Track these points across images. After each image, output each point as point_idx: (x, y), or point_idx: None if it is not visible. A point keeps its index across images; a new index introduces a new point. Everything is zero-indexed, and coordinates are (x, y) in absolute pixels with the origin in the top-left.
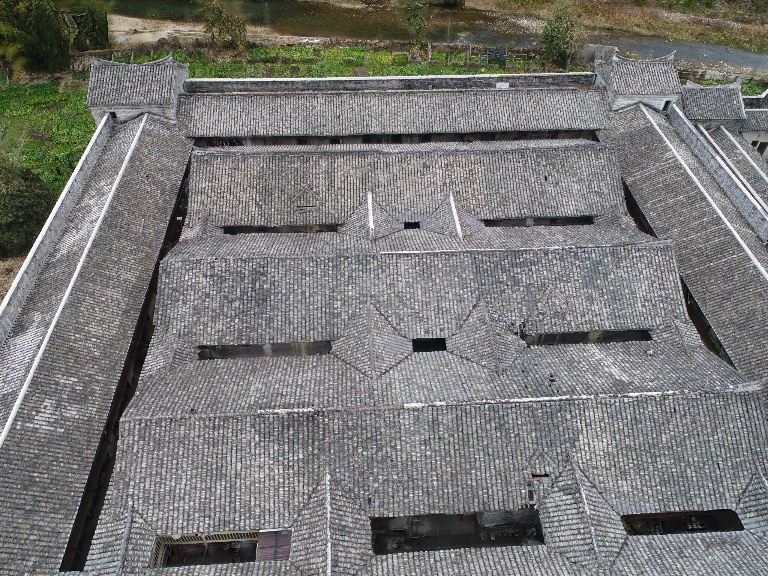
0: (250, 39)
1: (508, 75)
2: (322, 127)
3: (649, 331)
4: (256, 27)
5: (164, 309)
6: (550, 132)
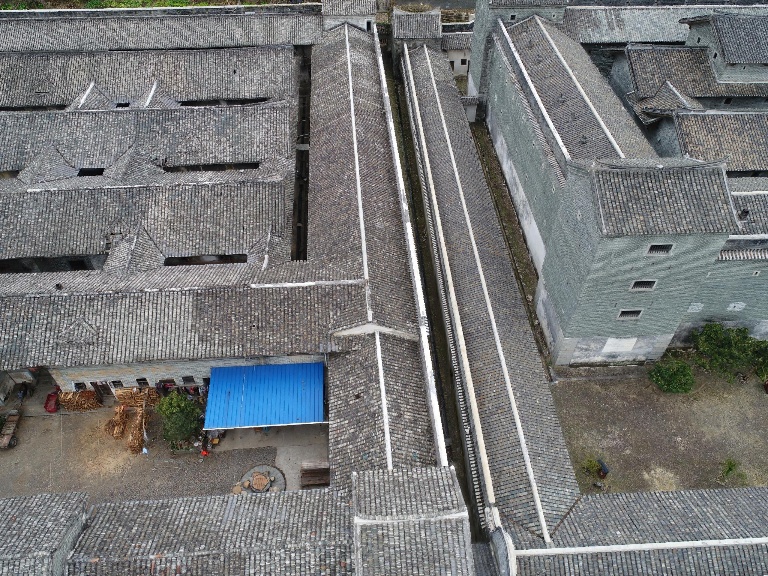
0: None
1: (252, 6)
2: (88, 44)
3: (259, 164)
4: None
5: None
6: None
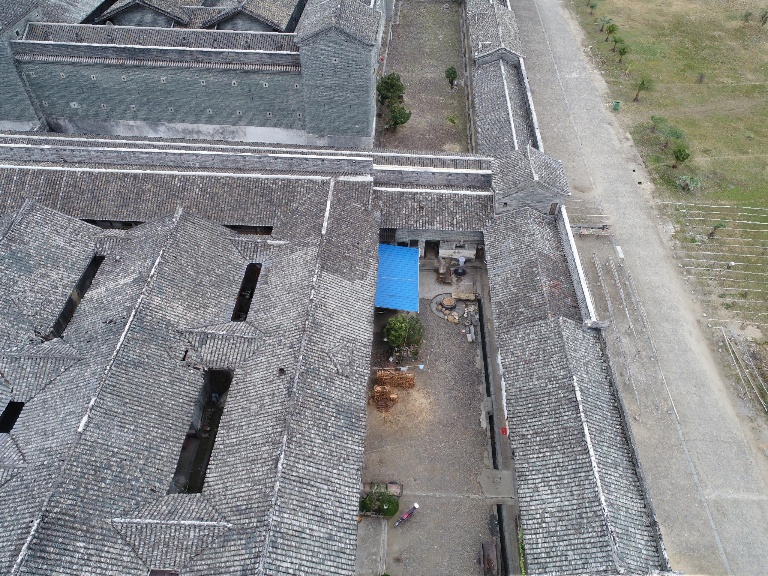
0: None
1: None
2: None
3: (96, 255)
4: None
5: None
6: None
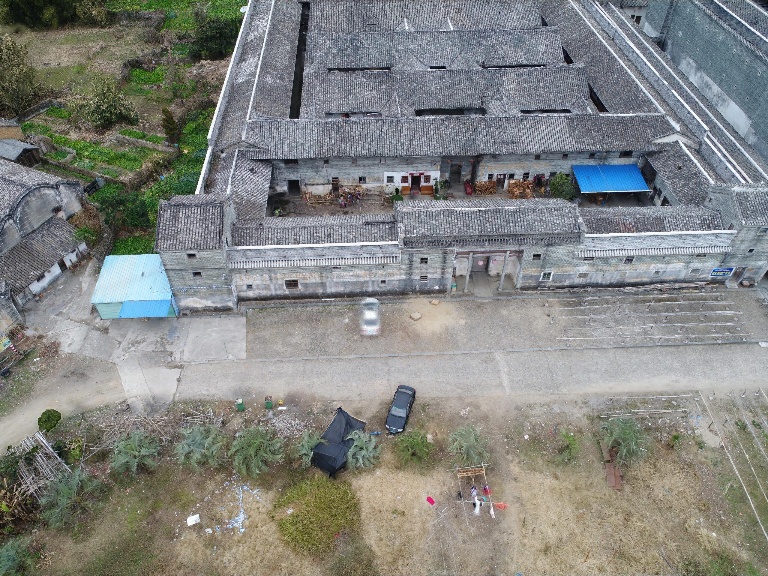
0: None
1: None
2: None
3: (545, 66)
4: None
5: (310, 53)
6: None
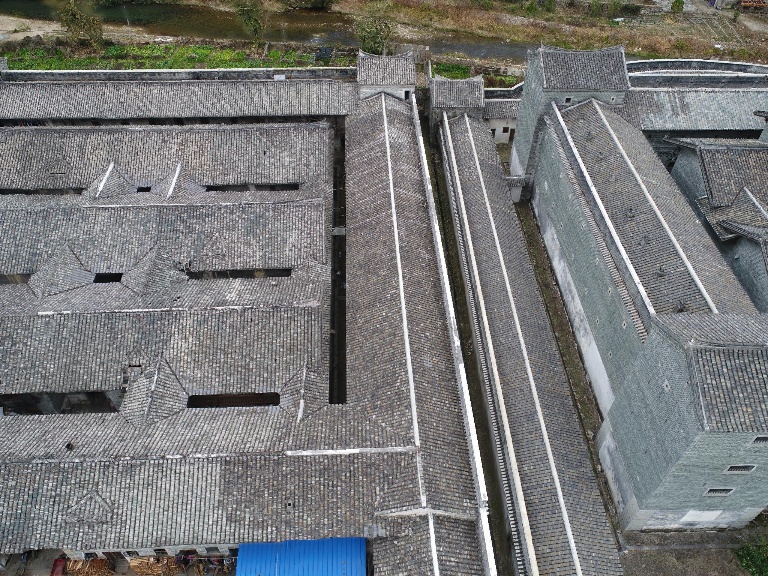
0: (116, 38)
1: (282, 69)
2: (108, 111)
3: (292, 270)
4: (132, 28)
5: None
6: (307, 117)
